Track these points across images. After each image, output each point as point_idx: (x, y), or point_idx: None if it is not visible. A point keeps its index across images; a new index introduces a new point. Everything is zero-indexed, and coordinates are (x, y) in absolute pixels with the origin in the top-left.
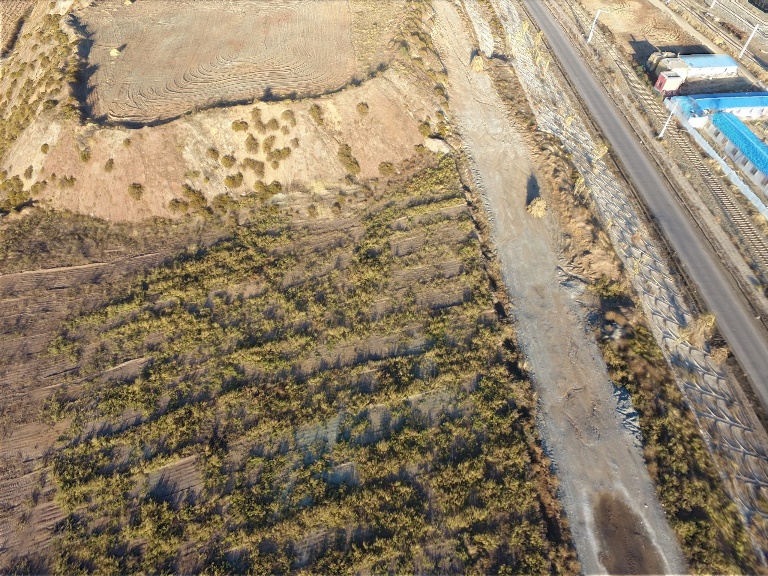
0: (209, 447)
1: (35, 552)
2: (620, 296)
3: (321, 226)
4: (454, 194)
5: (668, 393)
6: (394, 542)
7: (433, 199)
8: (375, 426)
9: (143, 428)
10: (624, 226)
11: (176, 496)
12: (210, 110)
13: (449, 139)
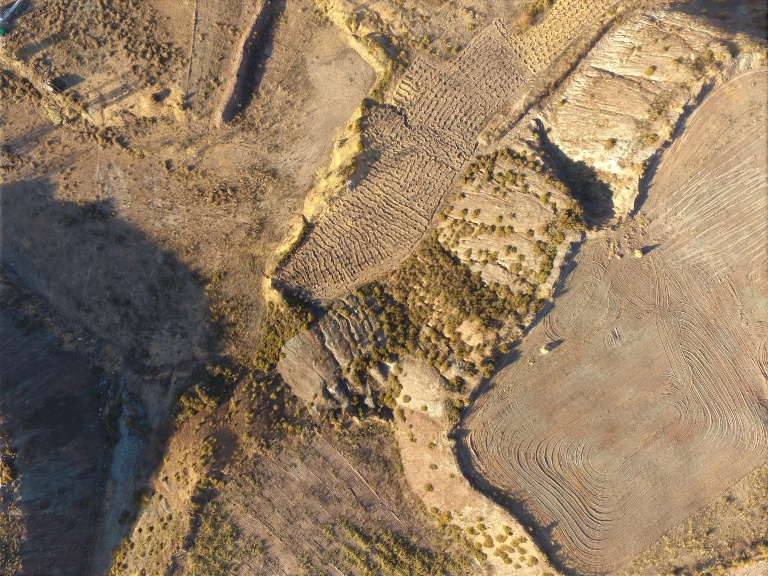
0: None
1: None
2: None
3: None
4: None
5: None
6: None
7: None
8: None
9: None
10: None
11: None
12: (506, 513)
13: None
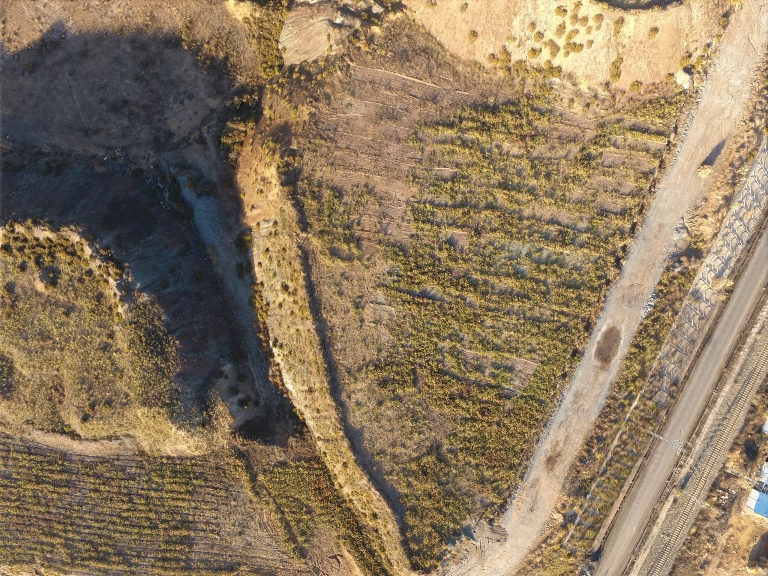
0: (474, 232)
1: (402, 242)
2: (699, 250)
3: (570, 118)
4: (664, 131)
5: (675, 304)
6: (530, 302)
7: (649, 129)
8: (543, 256)
9: (449, 210)
10: (749, 202)
11: (456, 246)
12: None
13: (697, 75)
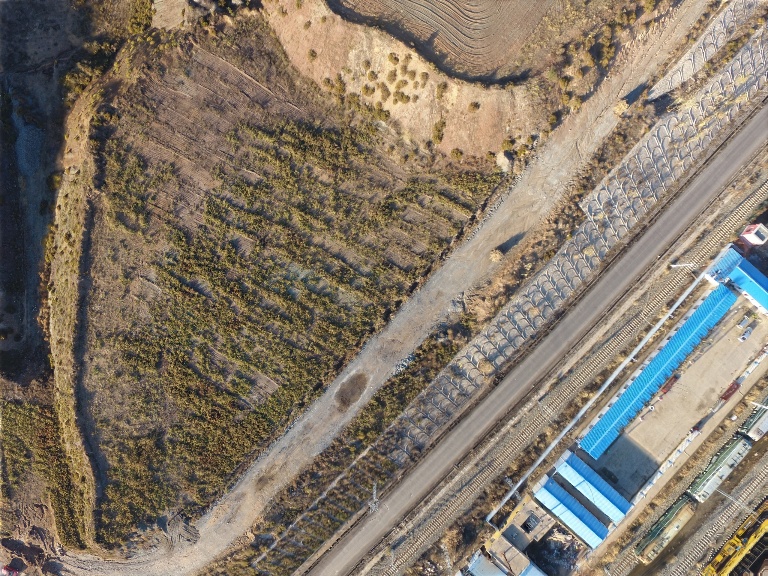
0: (259, 242)
1: (190, 229)
2: (468, 328)
3: (387, 164)
4: (472, 206)
5: (429, 372)
6: (291, 325)
7: (458, 199)
8: (318, 286)
9: (242, 213)
10: (538, 299)
11: (239, 250)
12: (384, 33)
13: (517, 162)
